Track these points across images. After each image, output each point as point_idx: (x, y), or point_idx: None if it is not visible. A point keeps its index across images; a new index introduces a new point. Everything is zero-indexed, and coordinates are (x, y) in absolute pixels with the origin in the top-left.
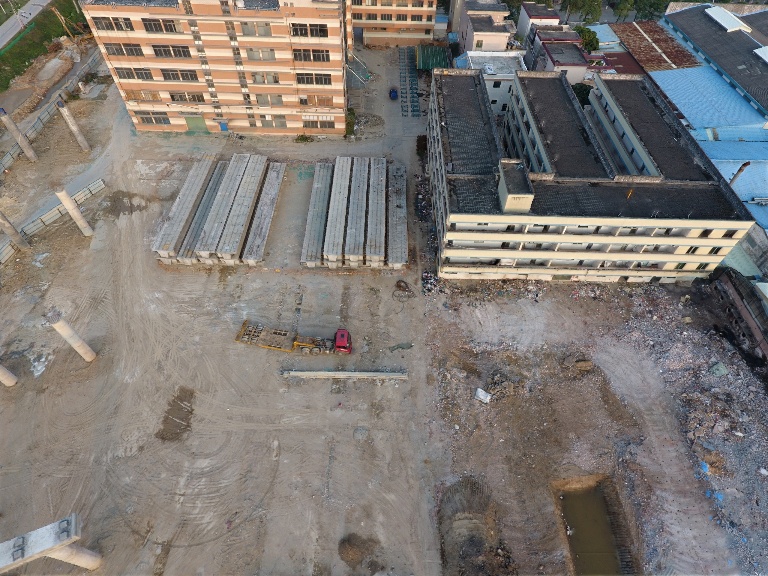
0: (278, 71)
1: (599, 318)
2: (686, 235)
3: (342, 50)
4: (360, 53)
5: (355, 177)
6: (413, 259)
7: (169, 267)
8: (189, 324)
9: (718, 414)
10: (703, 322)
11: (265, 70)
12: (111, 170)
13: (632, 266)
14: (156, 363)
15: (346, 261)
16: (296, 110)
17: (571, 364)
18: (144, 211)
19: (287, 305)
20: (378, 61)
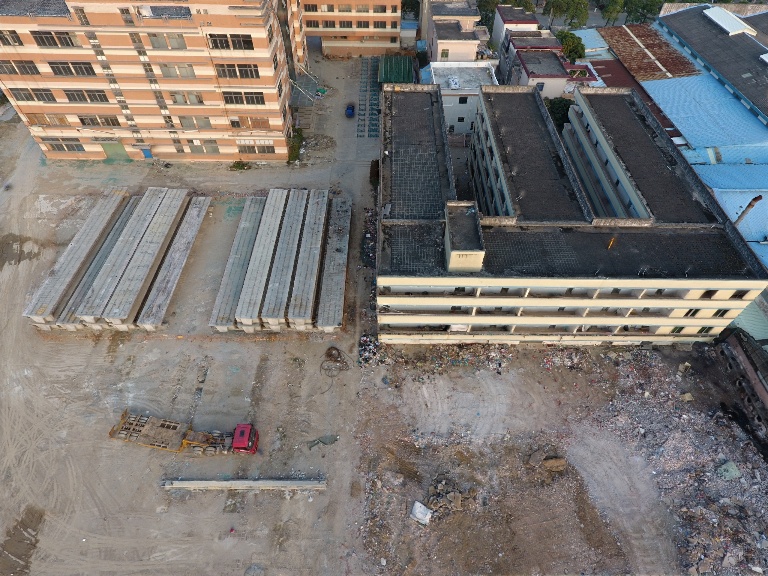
0: (200, 90)
1: (576, 396)
2: (683, 296)
3: (276, 64)
4: (318, 65)
5: (288, 215)
6: (351, 318)
7: (49, 333)
8: (58, 413)
9: (729, 539)
10: (707, 399)
11: (185, 89)
12: (6, 208)
13: (617, 330)
14: (4, 470)
15: (265, 324)
16: (228, 134)
17: (538, 464)
18: (34, 259)
19: (186, 384)
20: (337, 73)
